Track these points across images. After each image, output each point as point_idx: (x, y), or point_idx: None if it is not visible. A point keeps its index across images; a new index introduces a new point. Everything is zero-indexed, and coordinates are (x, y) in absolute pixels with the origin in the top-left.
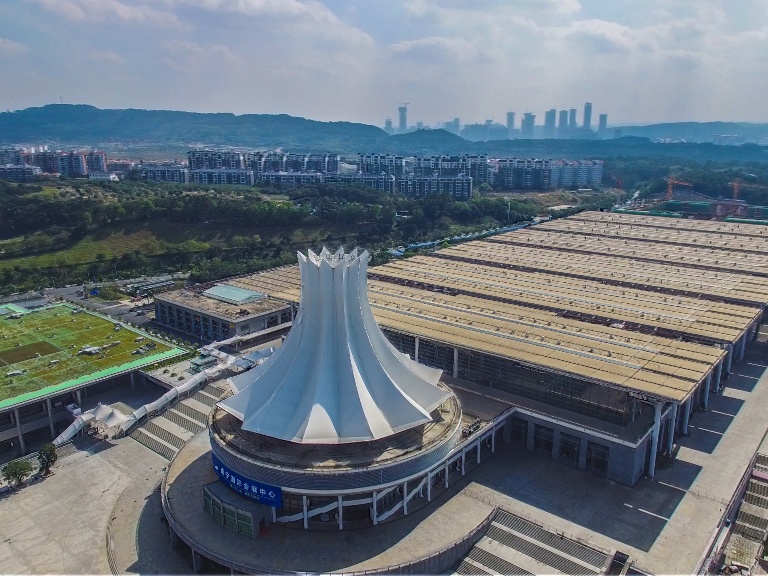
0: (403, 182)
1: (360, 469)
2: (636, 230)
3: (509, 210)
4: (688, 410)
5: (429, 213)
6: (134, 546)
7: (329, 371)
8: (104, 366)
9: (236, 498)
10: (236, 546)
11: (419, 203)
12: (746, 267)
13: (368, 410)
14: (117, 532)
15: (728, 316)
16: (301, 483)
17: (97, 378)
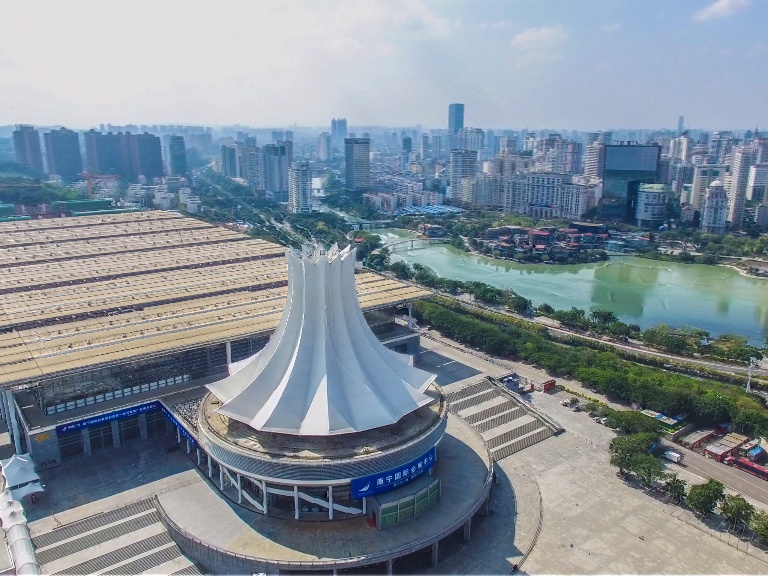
0: None
1: None
2: (50, 233)
3: None
4: None
5: None
6: None
7: None
8: None
9: (409, 488)
10: (448, 511)
11: None
12: (217, 238)
13: None
14: None
15: None
16: None
17: None
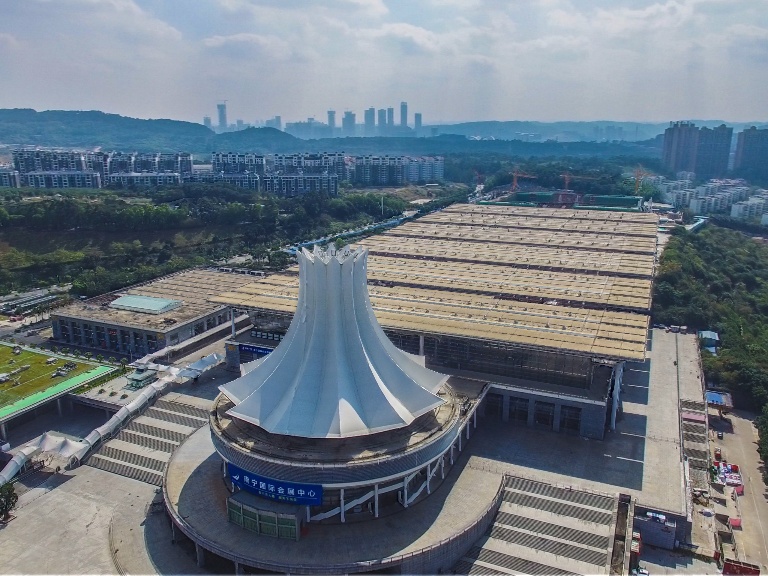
0: (269, 181)
1: (398, 455)
2: (509, 219)
3: (382, 205)
4: (622, 370)
5: (309, 211)
6: (156, 574)
7: (344, 366)
8: (26, 393)
9: (269, 504)
10: (283, 551)
11: (296, 201)
12: (617, 247)
13: (390, 399)
14: (128, 564)
15: (631, 288)
16: (343, 477)
17: (25, 407)
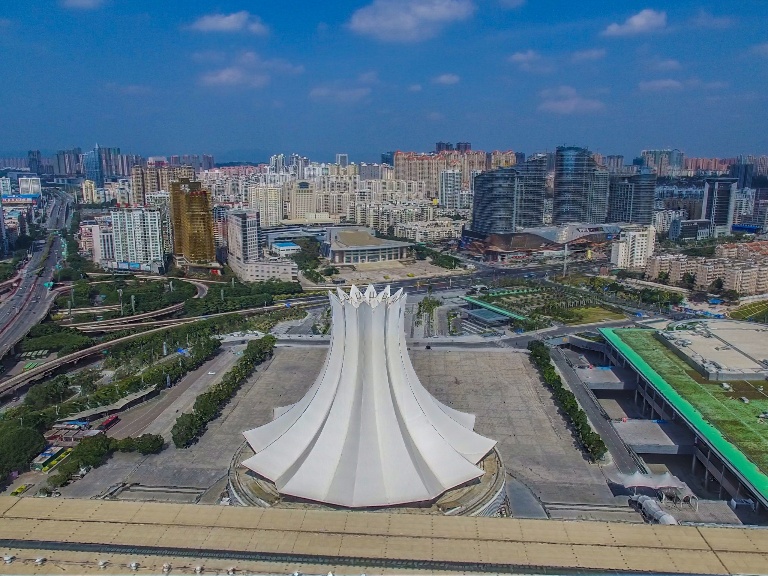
0: None
1: None
2: None
3: None
4: None
5: None
6: None
7: None
8: None
9: None
10: None
11: None
12: None
13: None
14: None
15: None
16: None
17: (759, 489)
